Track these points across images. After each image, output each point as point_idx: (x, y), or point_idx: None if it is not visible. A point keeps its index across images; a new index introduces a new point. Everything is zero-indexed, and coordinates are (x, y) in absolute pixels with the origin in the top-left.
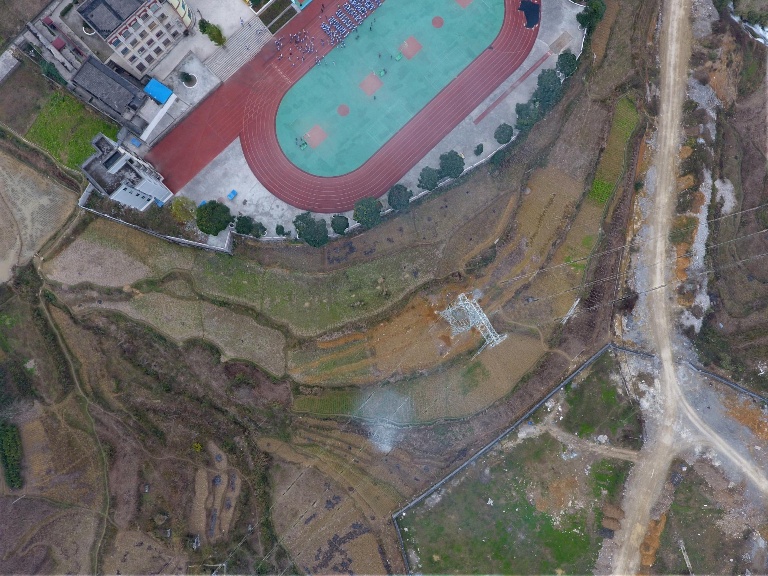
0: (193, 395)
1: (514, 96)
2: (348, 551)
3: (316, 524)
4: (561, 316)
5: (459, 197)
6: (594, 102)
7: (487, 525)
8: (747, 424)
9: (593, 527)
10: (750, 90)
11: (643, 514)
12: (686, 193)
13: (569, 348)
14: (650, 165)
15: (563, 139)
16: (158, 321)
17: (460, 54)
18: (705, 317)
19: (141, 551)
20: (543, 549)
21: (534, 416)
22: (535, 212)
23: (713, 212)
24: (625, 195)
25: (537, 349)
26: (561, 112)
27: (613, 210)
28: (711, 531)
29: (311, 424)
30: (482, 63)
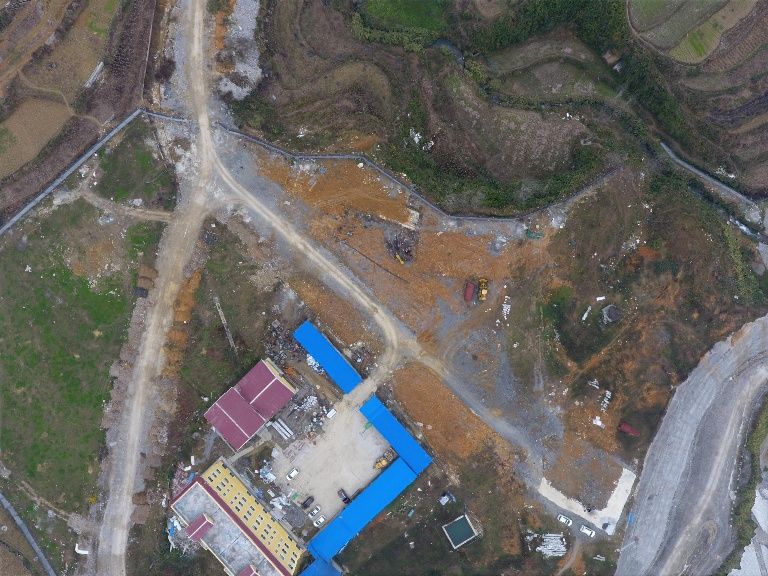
0: None
1: None
2: None
3: None
4: (84, 80)
5: None
6: None
7: (26, 292)
8: (277, 181)
9: (129, 288)
10: None
11: (176, 272)
12: None
13: (99, 114)
14: None
15: None
16: None
17: None
18: (256, 89)
19: None
20: (80, 312)
21: (68, 183)
22: None
23: None
24: None
25: (63, 114)
26: None
27: None
28: (245, 287)
29: None
30: None
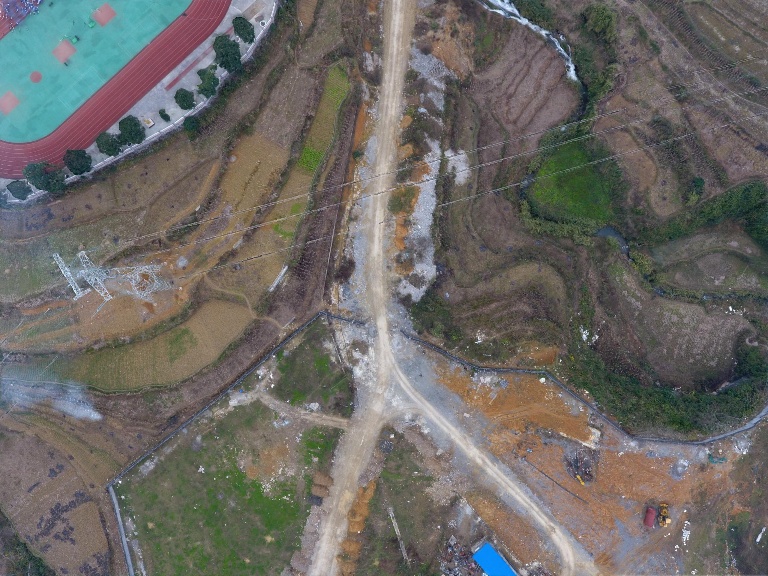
0: None
1: (206, 62)
2: (70, 519)
3: (39, 493)
4: (268, 284)
5: (159, 164)
6: (301, 70)
7: (198, 492)
8: (457, 392)
9: (303, 494)
10: (487, 61)
11: (352, 481)
12: (405, 162)
13: (280, 316)
14: (371, 134)
15: (270, 107)
16: None
17: (154, 21)
18: (431, 287)
19: None
20: (252, 516)
21: (245, 384)
22: (240, 180)
23: (442, 182)
24: (337, 163)
25: (245, 317)
26: (263, 80)
27: (325, 178)
28: (420, 498)
29: (23, 392)
30: (175, 30)
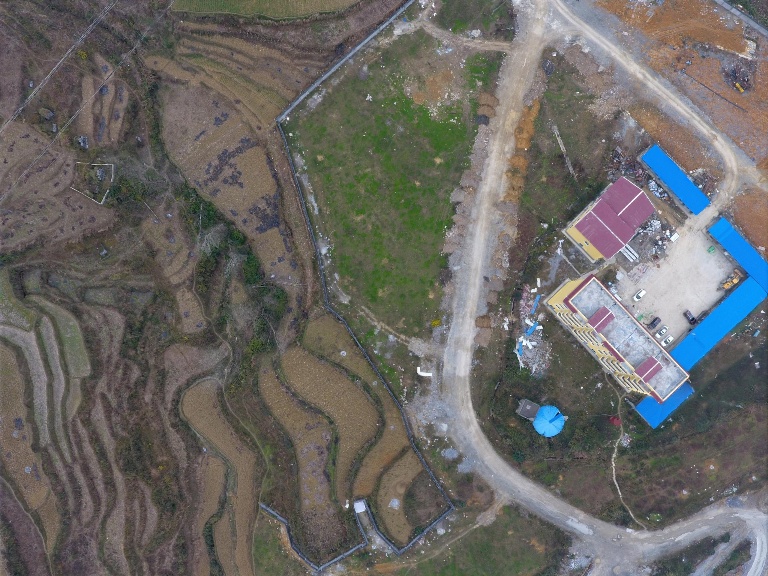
0: (79, 14)
1: None
2: (237, 164)
3: (206, 140)
4: None
5: None
6: None
7: (367, 120)
8: (615, 12)
9: (469, 117)
10: None
11: (517, 101)
12: None
13: None
14: None
15: None
16: None
17: None
18: None
19: (27, 143)
20: (421, 139)
21: (408, 13)
22: None
23: None
24: None
25: None
26: None
27: None
28: (583, 116)
29: (192, 28)
30: None
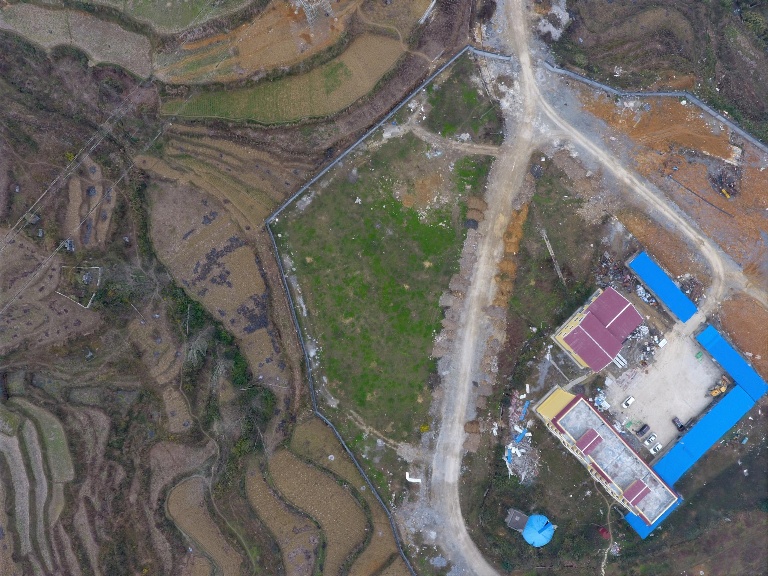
0: (68, 113)
1: None
2: (226, 263)
3: (194, 239)
4: (418, 16)
5: None
6: None
7: (356, 223)
8: (602, 117)
9: (458, 220)
10: None
11: (505, 205)
12: None
13: (429, 50)
14: None
15: None
16: (26, 30)
17: None
18: (565, 32)
19: (13, 248)
20: (410, 243)
21: (398, 117)
22: None
23: None
24: None
25: (397, 49)
26: None
27: None
28: (572, 220)
29: (181, 131)
30: None
